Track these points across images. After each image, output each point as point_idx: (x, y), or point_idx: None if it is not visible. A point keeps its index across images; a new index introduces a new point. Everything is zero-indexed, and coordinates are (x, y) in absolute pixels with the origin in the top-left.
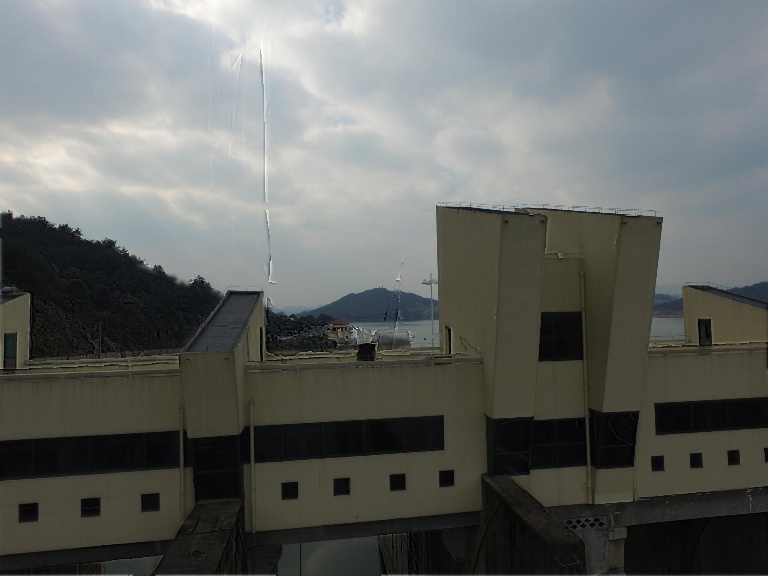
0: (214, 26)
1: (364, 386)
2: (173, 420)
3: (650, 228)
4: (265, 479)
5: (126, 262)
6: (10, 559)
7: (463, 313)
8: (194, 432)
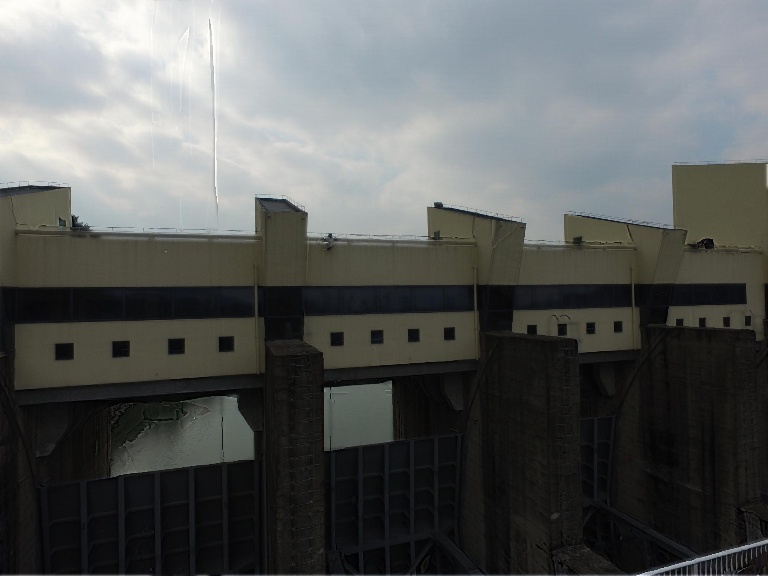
0: None
1: (711, 263)
2: (626, 278)
3: None
4: (669, 316)
5: None
6: None
7: (725, 229)
8: (656, 280)
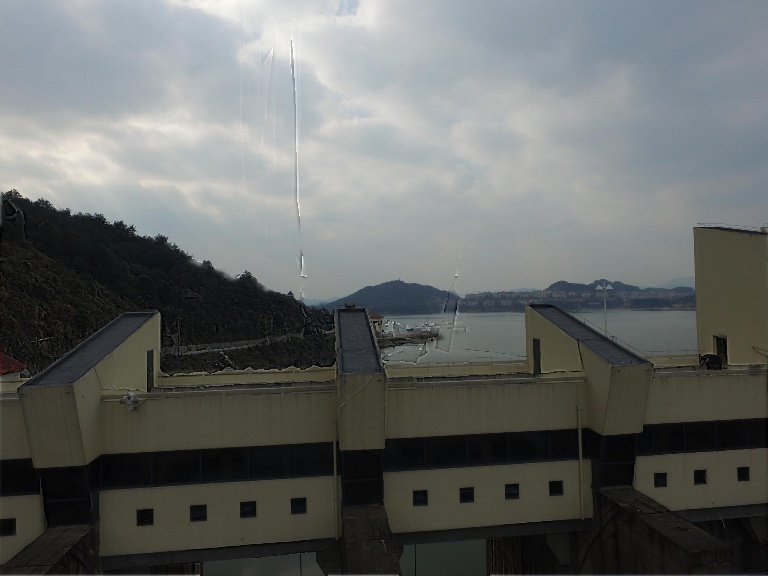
0: (244, 21)
1: (715, 392)
2: (570, 420)
3: None
4: (642, 470)
5: (180, 258)
6: (451, 533)
7: (760, 326)
8: (608, 430)
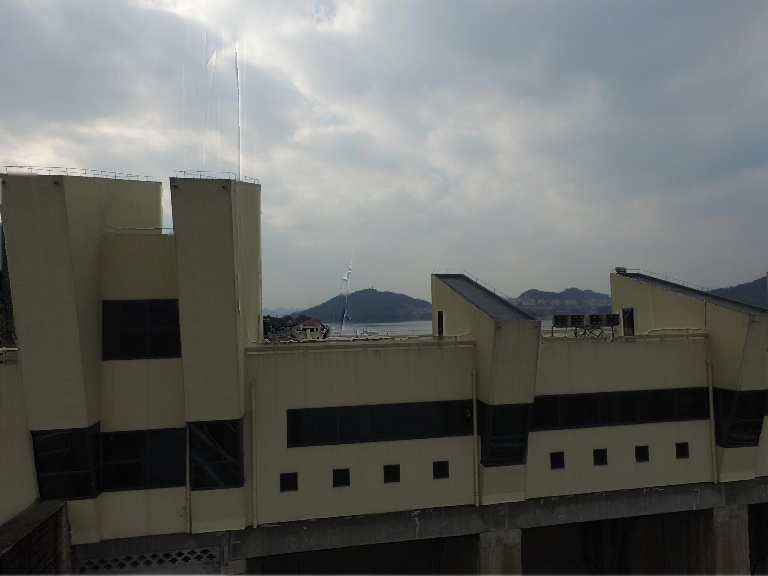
0: (189, 24)
1: None
2: None
3: (216, 194)
4: None
5: None
6: None
7: None
8: None
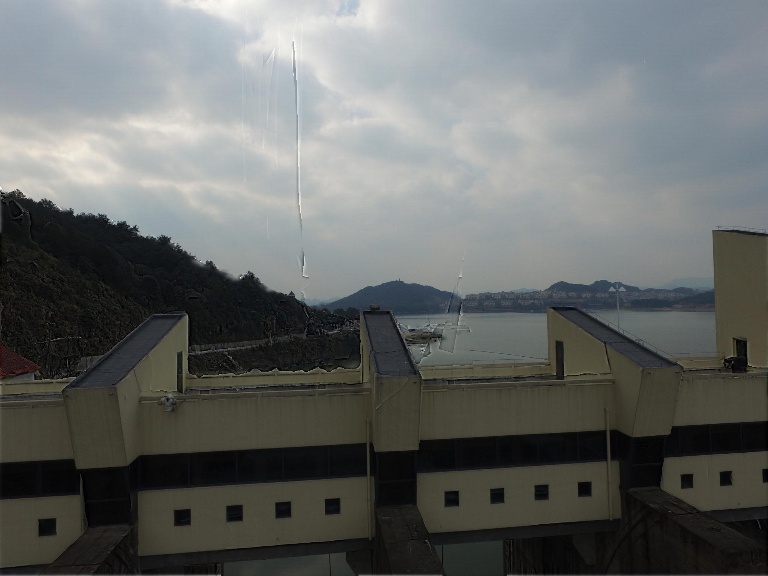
0: (246, 22)
1: (741, 394)
2: (598, 421)
3: None
4: (668, 471)
5: (184, 258)
6: (482, 533)
7: None
8: (638, 432)
